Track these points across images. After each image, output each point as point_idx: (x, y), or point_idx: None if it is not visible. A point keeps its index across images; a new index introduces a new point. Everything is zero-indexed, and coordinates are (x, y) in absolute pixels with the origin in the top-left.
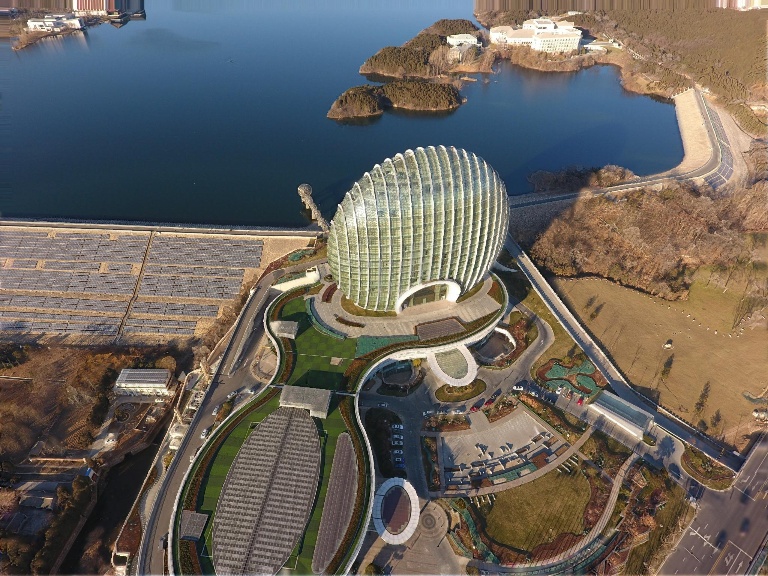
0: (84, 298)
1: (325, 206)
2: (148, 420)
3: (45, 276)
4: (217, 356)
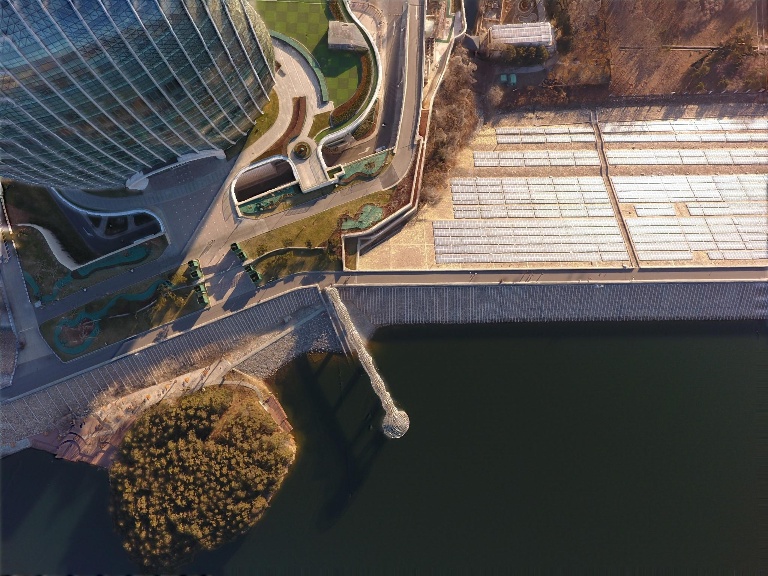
0: (678, 166)
1: (358, 418)
2: (496, 4)
3: (763, 193)
4: (442, 66)
